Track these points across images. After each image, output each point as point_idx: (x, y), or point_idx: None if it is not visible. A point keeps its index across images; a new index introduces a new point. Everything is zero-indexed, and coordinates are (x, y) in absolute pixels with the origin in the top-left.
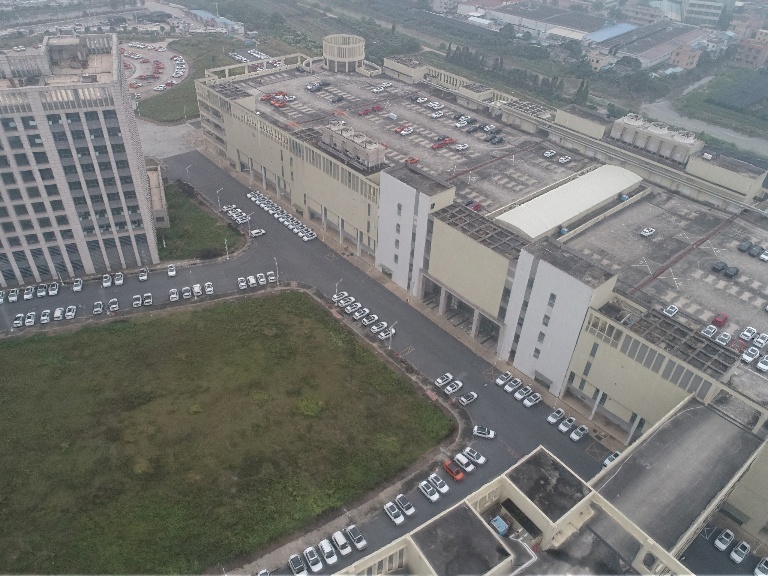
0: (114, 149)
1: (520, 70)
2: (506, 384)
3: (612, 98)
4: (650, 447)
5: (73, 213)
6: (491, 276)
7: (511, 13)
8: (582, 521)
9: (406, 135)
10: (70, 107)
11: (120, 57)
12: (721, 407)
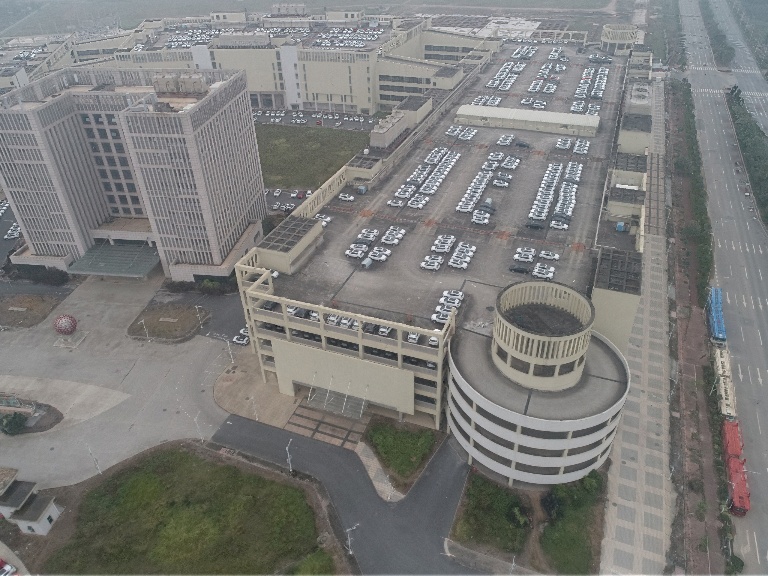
0: None
1: None
2: None
3: None
4: None
5: None
6: None
7: None
8: None
9: None
10: None
11: None
12: None
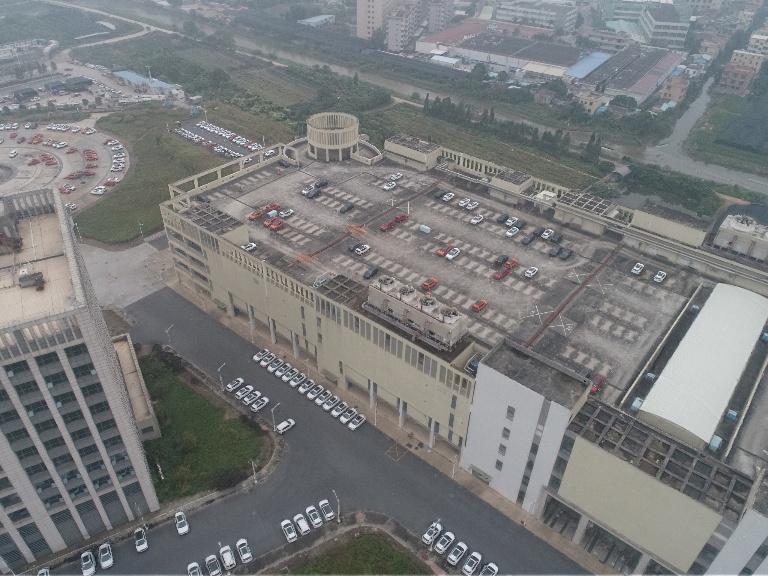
0: (85, 391)
1: (515, 123)
2: None
3: (616, 145)
4: None
5: (27, 488)
6: (682, 526)
7: (477, 49)
8: None
9: (453, 259)
10: (10, 356)
11: (68, 221)
12: None
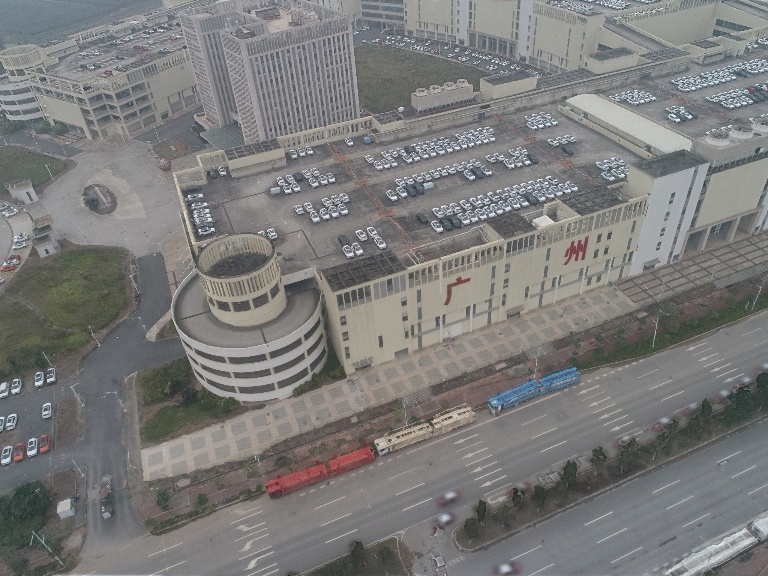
0: None
1: None
2: None
3: None
4: None
5: None
6: None
7: None
8: None
9: None
10: None
11: None
12: None
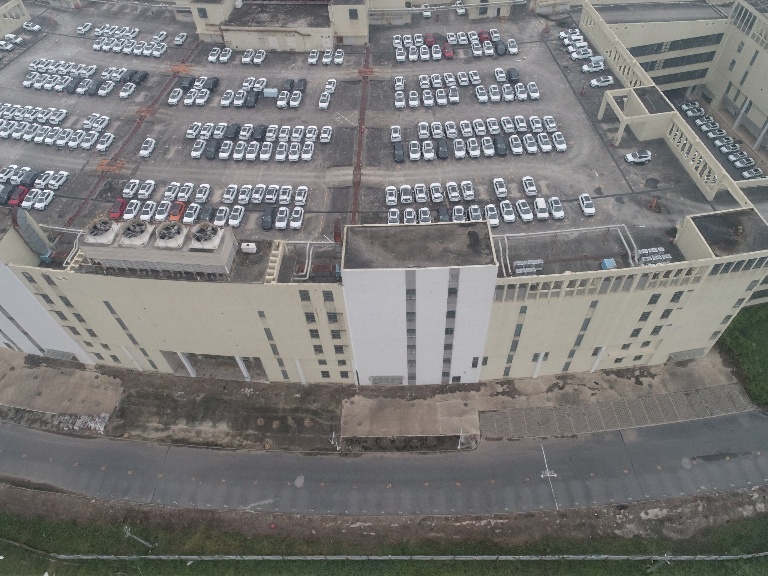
0: None
1: None
2: None
3: None
4: (643, 5)
5: None
6: None
7: None
8: (562, 1)
9: None
10: None
11: None
12: (720, 7)
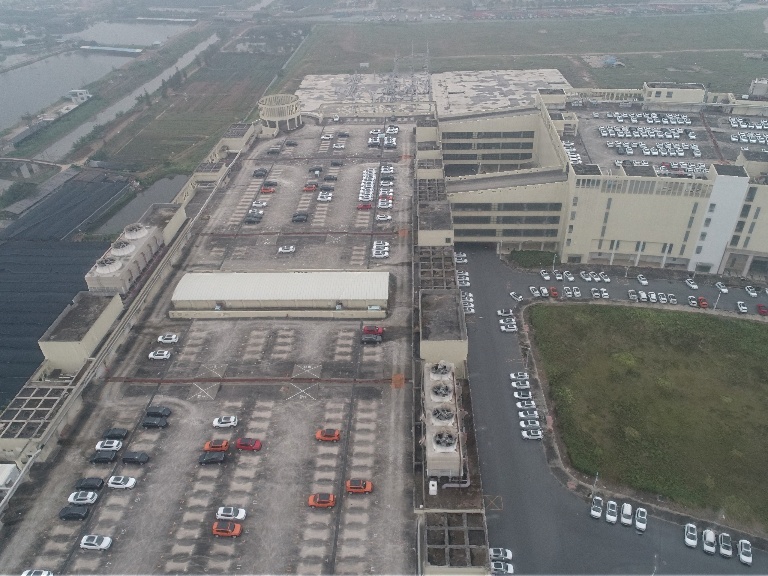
0: None
1: None
2: (470, 307)
3: None
4: None
5: None
6: None
7: None
8: None
9: None
10: None
11: None
12: None
